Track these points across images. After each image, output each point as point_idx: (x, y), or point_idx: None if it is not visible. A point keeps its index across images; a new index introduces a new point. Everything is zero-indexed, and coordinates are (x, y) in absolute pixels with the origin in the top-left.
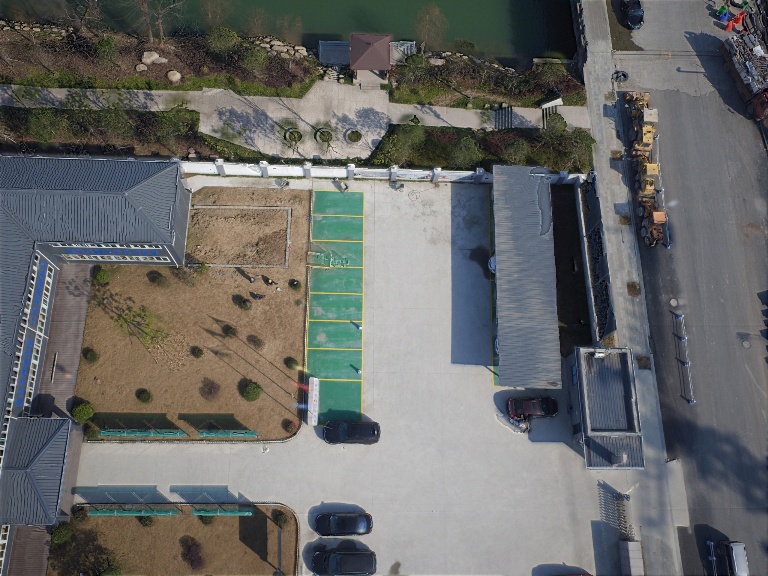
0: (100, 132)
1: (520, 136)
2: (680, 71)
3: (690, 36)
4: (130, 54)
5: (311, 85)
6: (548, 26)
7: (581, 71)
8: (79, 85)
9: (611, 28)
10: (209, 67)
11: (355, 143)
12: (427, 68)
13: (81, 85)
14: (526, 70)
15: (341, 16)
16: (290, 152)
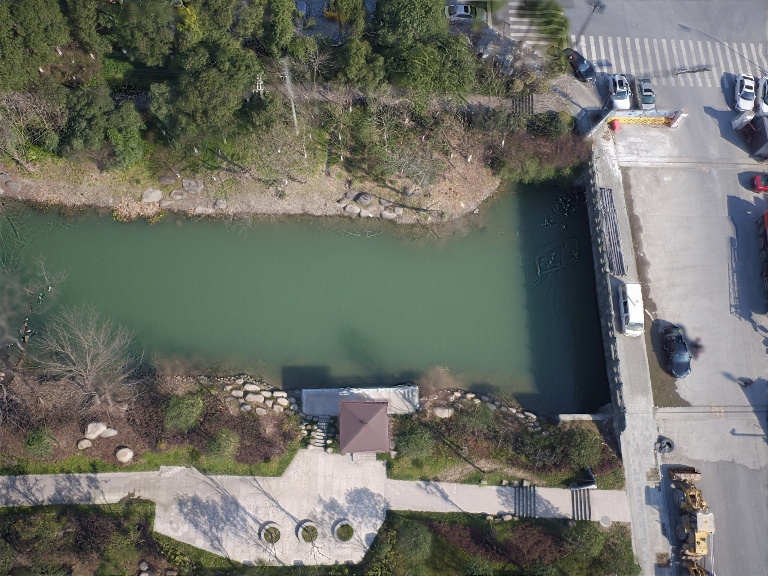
0: (29, 553)
1: (546, 534)
2: (735, 434)
3: (745, 383)
4: (71, 423)
5: (292, 457)
6: (575, 358)
7: (617, 436)
8: (7, 470)
9: (652, 375)
10: (168, 438)
11: (345, 543)
12: (432, 425)
13: (9, 470)
14: (550, 423)
15: (329, 342)
16: (266, 557)
